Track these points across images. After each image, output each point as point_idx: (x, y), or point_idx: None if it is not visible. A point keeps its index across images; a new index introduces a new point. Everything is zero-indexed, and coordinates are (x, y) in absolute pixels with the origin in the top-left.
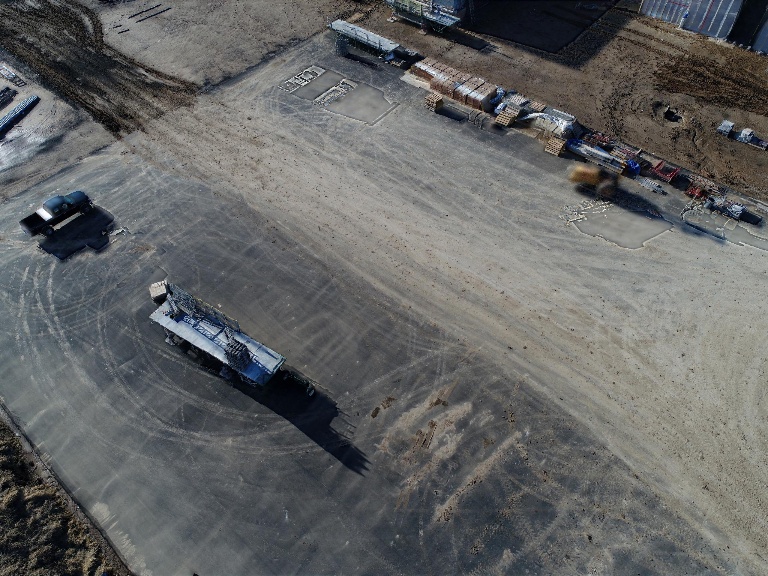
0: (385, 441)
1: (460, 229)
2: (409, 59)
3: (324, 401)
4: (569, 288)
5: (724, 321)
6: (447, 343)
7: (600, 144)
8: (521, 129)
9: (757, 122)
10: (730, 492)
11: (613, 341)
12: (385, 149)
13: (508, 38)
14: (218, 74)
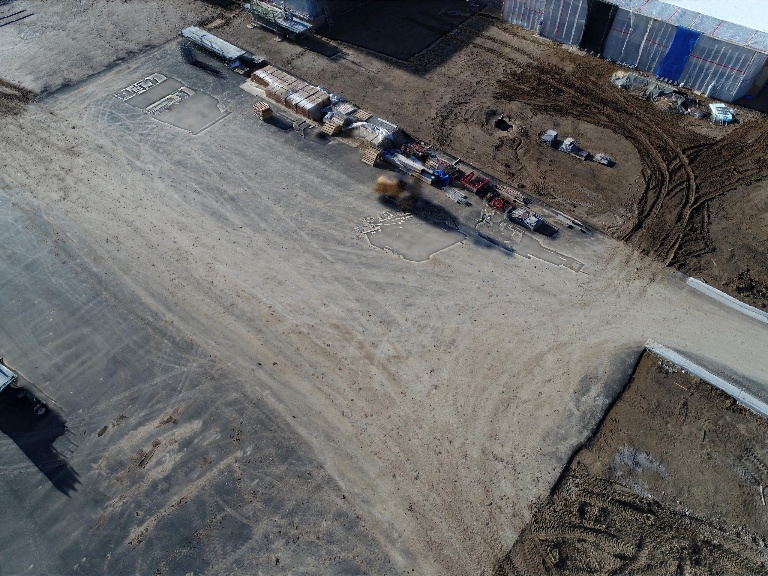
0: (103, 461)
1: (249, 241)
2: (255, 66)
3: (55, 419)
4: (339, 302)
5: (485, 336)
6: (197, 359)
7: (417, 154)
8: (345, 138)
9: (585, 131)
10: (433, 513)
11: (366, 357)
12: (201, 159)
13: (362, 45)
14: (58, 82)
